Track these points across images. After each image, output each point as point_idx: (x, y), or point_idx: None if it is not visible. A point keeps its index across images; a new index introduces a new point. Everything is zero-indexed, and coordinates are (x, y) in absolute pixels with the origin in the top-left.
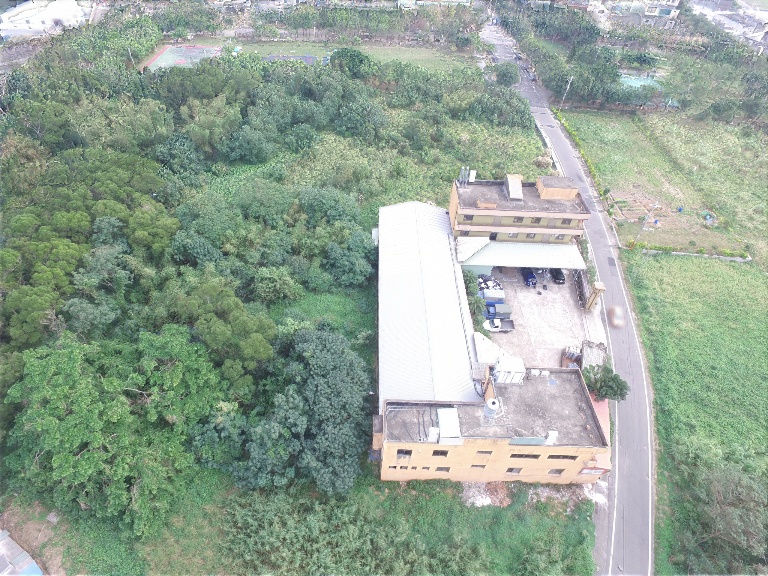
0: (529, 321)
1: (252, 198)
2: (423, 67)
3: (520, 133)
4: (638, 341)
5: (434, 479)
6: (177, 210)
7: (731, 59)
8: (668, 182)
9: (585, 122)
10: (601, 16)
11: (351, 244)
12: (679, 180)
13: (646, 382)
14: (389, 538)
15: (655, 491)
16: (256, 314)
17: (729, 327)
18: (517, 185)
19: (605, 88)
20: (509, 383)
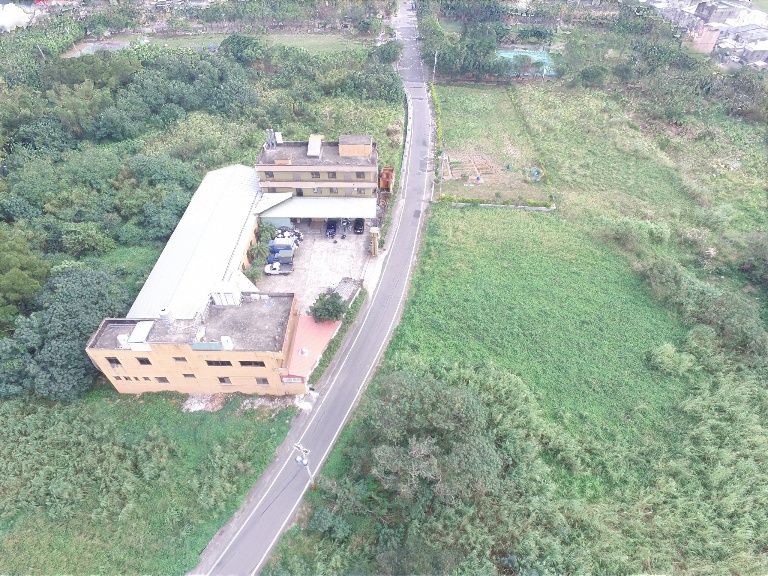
0: (313, 265)
1: (79, 165)
2: (305, 49)
3: (385, 105)
4: (407, 280)
5: (163, 391)
6: (8, 176)
7: (633, 29)
8: (512, 144)
9: (458, 94)
10: None
11: (165, 202)
12: (524, 142)
13: (397, 313)
14: (94, 433)
15: (359, 400)
16: (57, 262)
17: (501, 266)
18: (316, 144)
19: None
20: (227, 305)
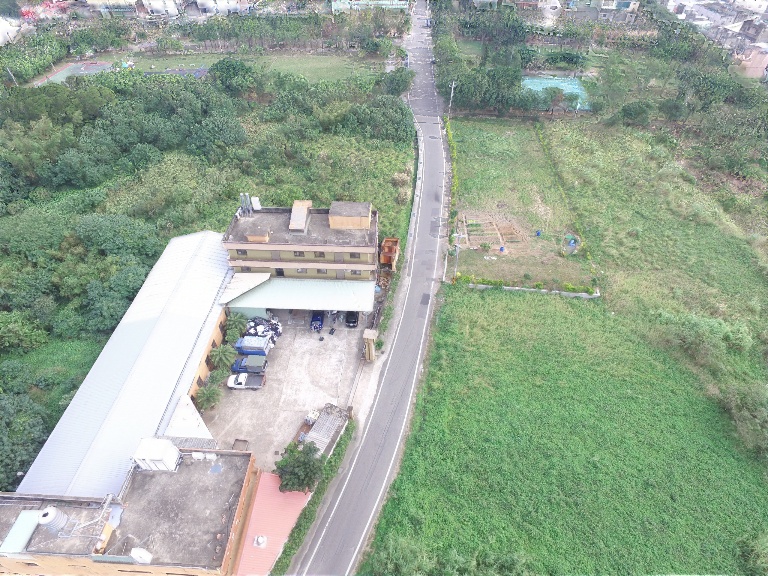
0: (290, 375)
1: (13, 232)
2: (303, 77)
3: (392, 146)
4: (410, 402)
5: None
6: None
7: (676, 54)
8: (541, 200)
9: (477, 131)
10: (554, 12)
11: (113, 282)
12: (556, 197)
13: (395, 457)
14: None
15: None
16: None
17: (533, 384)
18: (301, 213)
19: (500, 93)
20: (158, 470)
